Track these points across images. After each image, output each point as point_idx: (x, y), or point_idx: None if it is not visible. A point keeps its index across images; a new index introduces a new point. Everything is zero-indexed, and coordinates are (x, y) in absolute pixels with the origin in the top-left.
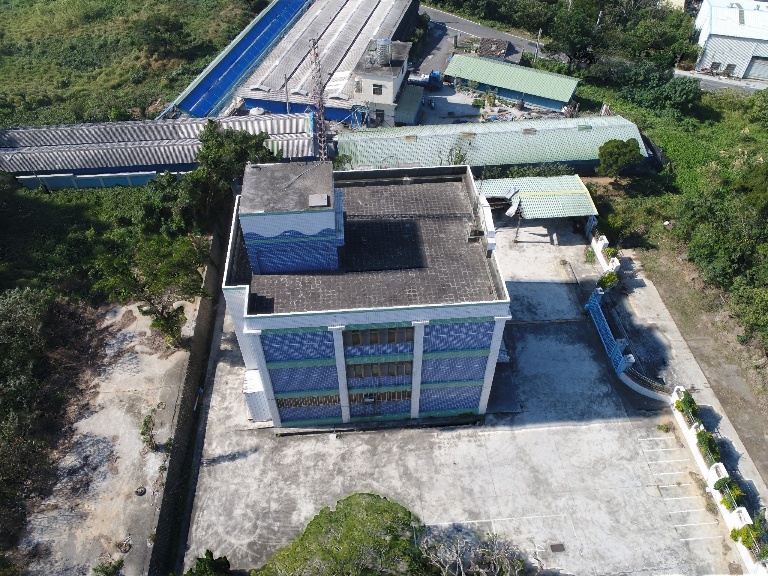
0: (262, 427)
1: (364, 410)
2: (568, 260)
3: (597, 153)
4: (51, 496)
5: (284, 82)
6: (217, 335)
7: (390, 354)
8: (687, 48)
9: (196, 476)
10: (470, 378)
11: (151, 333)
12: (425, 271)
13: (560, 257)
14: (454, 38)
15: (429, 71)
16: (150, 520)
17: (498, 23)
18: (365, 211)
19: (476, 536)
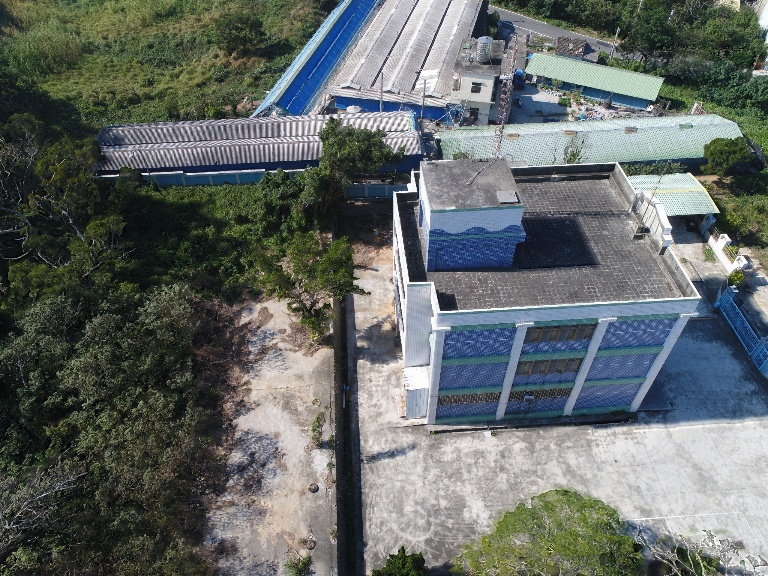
0: (416, 424)
1: (519, 407)
2: (688, 258)
3: (700, 151)
4: (226, 493)
5: (373, 80)
6: (351, 332)
7: (564, 351)
8: None
9: (359, 473)
10: (633, 375)
11: (291, 330)
12: (598, 268)
13: (679, 255)
14: (526, 37)
15: (507, 70)
16: (329, 517)
17: (564, 22)
18: None
19: (652, 533)
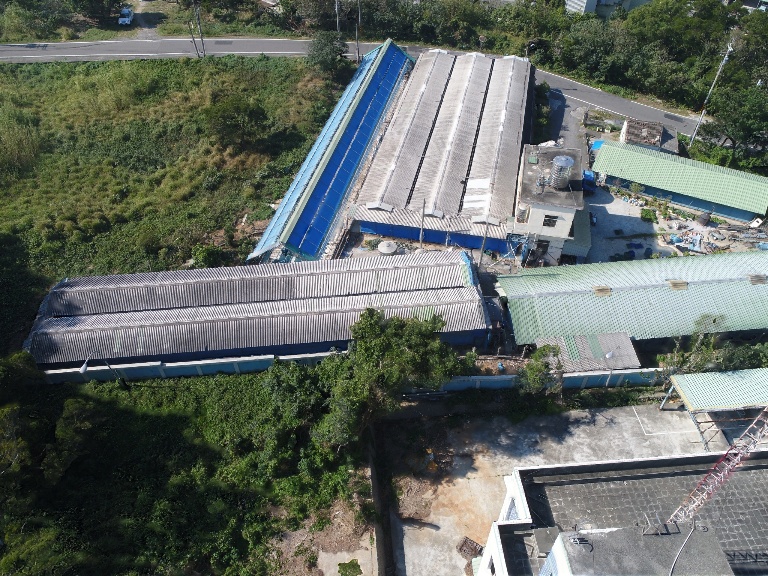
0: None
1: None
2: None
3: None
4: None
5: (408, 196)
6: None
7: None
8: None
9: None
10: None
11: None
12: None
13: None
14: (584, 115)
15: None
16: None
17: (621, 88)
18: None
19: None
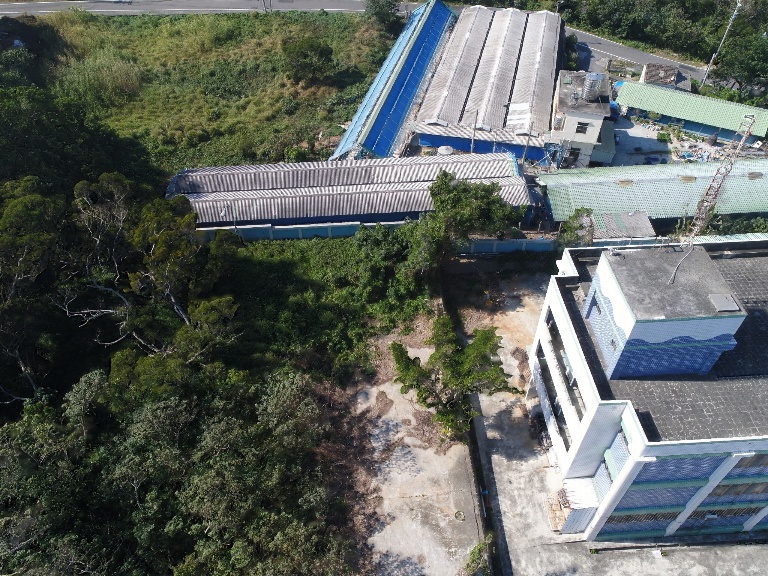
0: (572, 541)
1: (693, 523)
2: None
3: None
4: None
5: (459, 115)
6: (478, 420)
7: None
8: None
9: None
10: None
11: (416, 421)
12: None
13: None
14: (608, 62)
15: None
16: None
17: (641, 43)
18: None
19: None
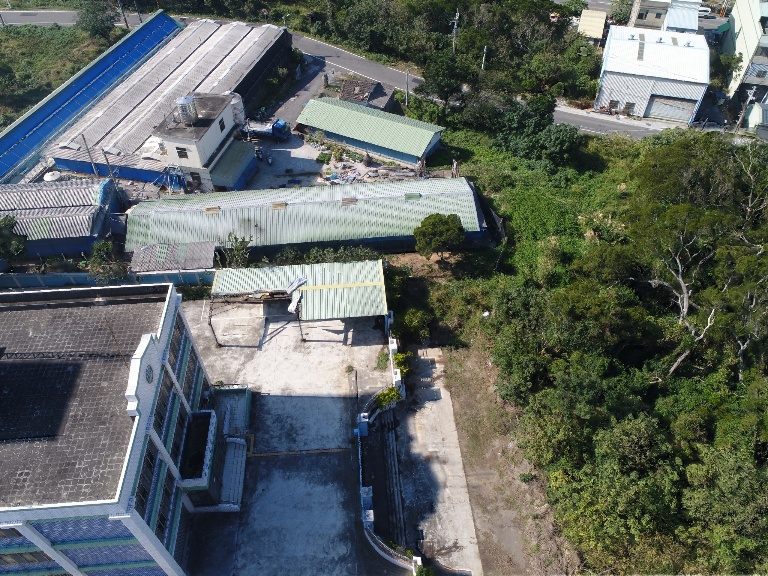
0: None
1: None
2: (356, 366)
3: None
4: None
5: (100, 138)
6: None
7: (10, 546)
8: (584, 84)
9: None
10: (140, 560)
11: None
12: (55, 441)
13: (348, 362)
14: (324, 77)
15: (284, 117)
16: None
17: (385, 56)
18: (29, 347)
19: None
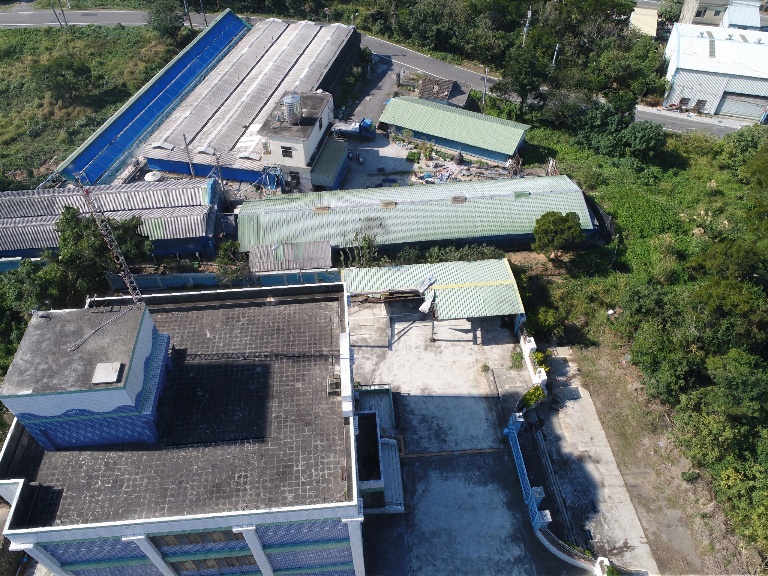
0: None
1: None
2: (491, 365)
3: (535, 225)
4: None
5: (192, 137)
6: None
7: (221, 550)
8: (653, 82)
9: None
10: (336, 563)
11: None
12: (266, 443)
13: (482, 361)
14: (396, 76)
15: (364, 116)
16: None
17: (450, 55)
18: (211, 348)
19: None
